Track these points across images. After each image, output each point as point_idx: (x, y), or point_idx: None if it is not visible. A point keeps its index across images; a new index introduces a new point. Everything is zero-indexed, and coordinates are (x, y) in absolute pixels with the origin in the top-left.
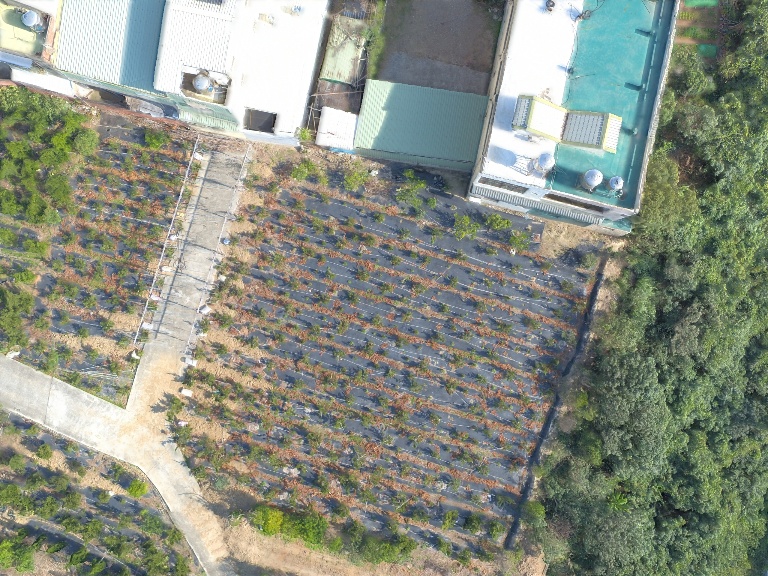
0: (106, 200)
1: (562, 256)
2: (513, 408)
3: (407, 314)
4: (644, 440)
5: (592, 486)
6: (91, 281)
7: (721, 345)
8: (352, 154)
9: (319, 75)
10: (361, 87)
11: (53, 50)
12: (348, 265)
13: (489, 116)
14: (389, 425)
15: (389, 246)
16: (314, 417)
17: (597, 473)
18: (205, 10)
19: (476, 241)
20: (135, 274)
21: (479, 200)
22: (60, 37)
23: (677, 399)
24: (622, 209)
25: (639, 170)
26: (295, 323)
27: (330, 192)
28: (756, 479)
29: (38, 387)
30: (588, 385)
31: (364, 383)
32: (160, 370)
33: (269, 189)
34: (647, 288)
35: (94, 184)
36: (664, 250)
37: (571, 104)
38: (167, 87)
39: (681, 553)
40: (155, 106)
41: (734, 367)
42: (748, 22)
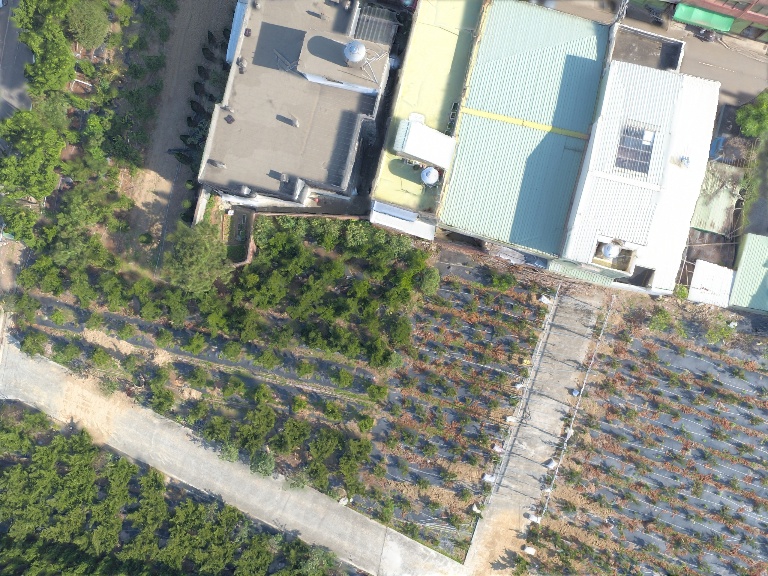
0: (446, 342)
1: None
2: None
3: (767, 479)
4: None
5: None
6: (429, 427)
7: None
8: (712, 305)
9: None
10: (735, 238)
11: (441, 204)
12: (704, 423)
13: None
14: None
15: (750, 405)
16: None
17: None
18: (631, 179)
19: None
20: (477, 423)
21: None
22: (449, 191)
23: None
24: None
25: None
26: (645, 482)
27: (684, 343)
28: None
29: (372, 537)
30: None
31: None
32: (501, 525)
33: (622, 339)
34: None
35: (434, 325)
36: None
37: None
38: (580, 257)
39: None
40: (517, 253)
41: None
42: None
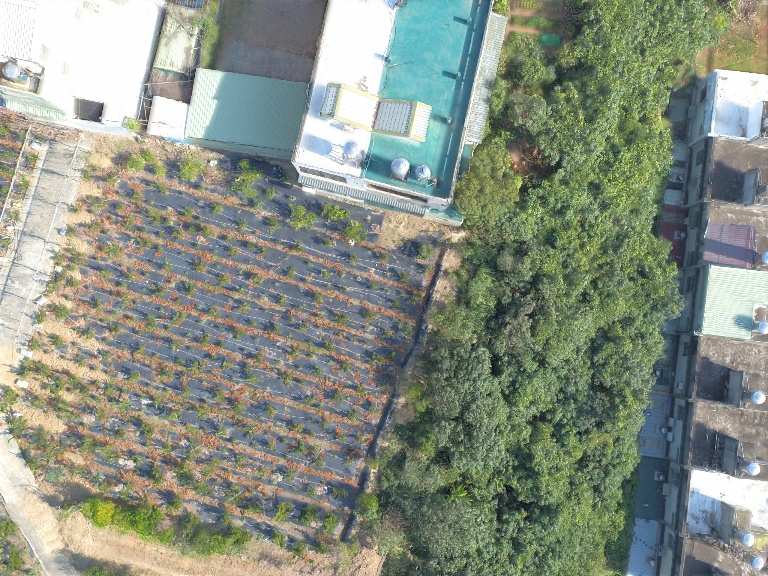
0: None
1: (401, 247)
2: (350, 399)
3: (243, 305)
4: (476, 431)
5: (424, 478)
6: None
7: (556, 336)
8: (190, 144)
9: (152, 64)
10: (194, 76)
11: None
12: (185, 256)
13: (305, 105)
14: (226, 416)
15: (226, 237)
16: (150, 408)
17: (437, 465)
18: None
19: (315, 232)
20: None
21: (312, 190)
22: None
23: (514, 390)
24: (435, 198)
25: (455, 159)
26: (132, 314)
27: (169, 182)
28: (610, 471)
29: None
30: (421, 376)
31: (201, 374)
32: None
33: (106, 179)
34: (485, 279)
35: None
36: (502, 241)
37: (388, 92)
38: None
39: (523, 545)
40: None
41: (577, 358)
42: (587, 10)
